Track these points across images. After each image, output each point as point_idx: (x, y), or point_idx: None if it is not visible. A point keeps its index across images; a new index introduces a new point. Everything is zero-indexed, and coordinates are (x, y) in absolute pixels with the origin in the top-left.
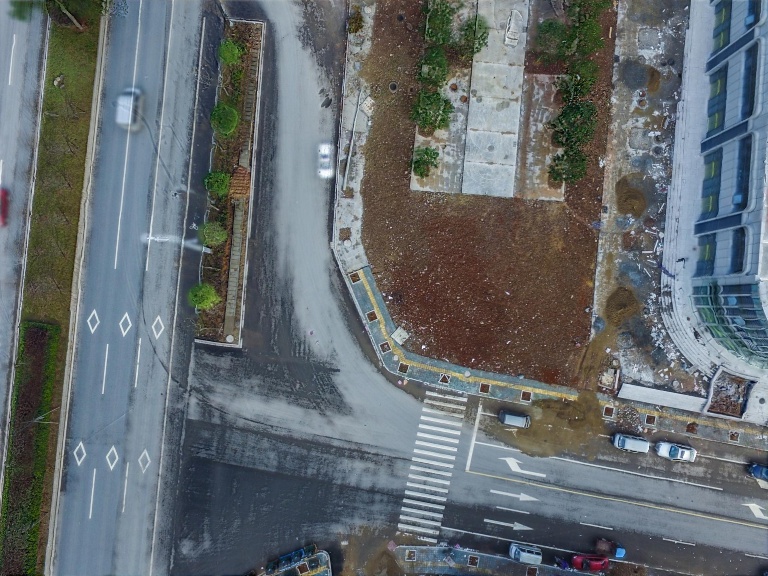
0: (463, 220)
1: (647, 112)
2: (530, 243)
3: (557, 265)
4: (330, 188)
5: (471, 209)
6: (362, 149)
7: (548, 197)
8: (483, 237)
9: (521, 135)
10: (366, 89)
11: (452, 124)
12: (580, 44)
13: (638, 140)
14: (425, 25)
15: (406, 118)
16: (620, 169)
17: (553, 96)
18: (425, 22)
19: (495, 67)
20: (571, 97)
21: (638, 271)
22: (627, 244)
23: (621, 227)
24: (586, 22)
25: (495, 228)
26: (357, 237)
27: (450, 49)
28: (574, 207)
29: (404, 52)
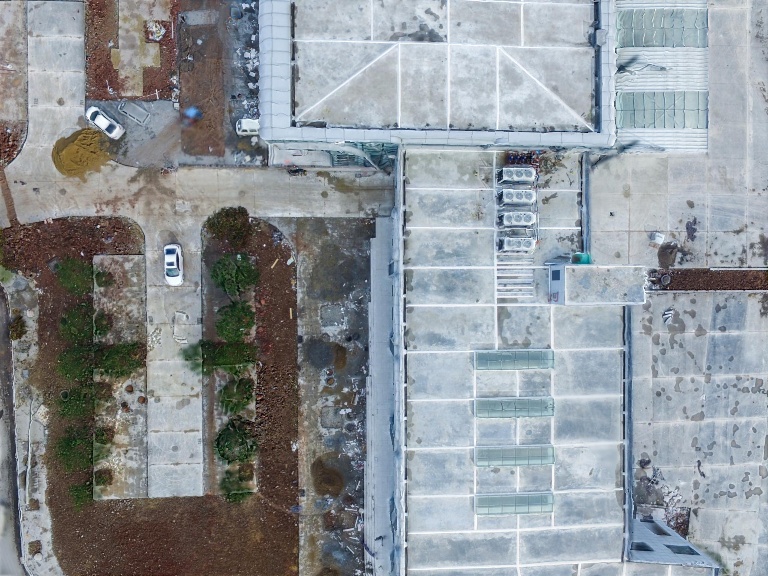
0: (154, 524)
1: (336, 389)
2: (226, 538)
3: (257, 556)
4: (13, 502)
5: (161, 512)
6: (43, 458)
7: (240, 490)
8: (177, 538)
9: (206, 430)
10: (38, 397)
11: (132, 427)
12: (258, 331)
13: (330, 419)
14: (92, 326)
15: (81, 427)
16: (314, 450)
17: (236, 386)
18: (92, 323)
19: (171, 364)
20: (254, 386)
21: (341, 550)
22: (328, 524)
23: (320, 508)
24: (262, 307)
25: (188, 528)
26: (48, 549)
27: (122, 348)
28: (269, 496)
29: (71, 359)
